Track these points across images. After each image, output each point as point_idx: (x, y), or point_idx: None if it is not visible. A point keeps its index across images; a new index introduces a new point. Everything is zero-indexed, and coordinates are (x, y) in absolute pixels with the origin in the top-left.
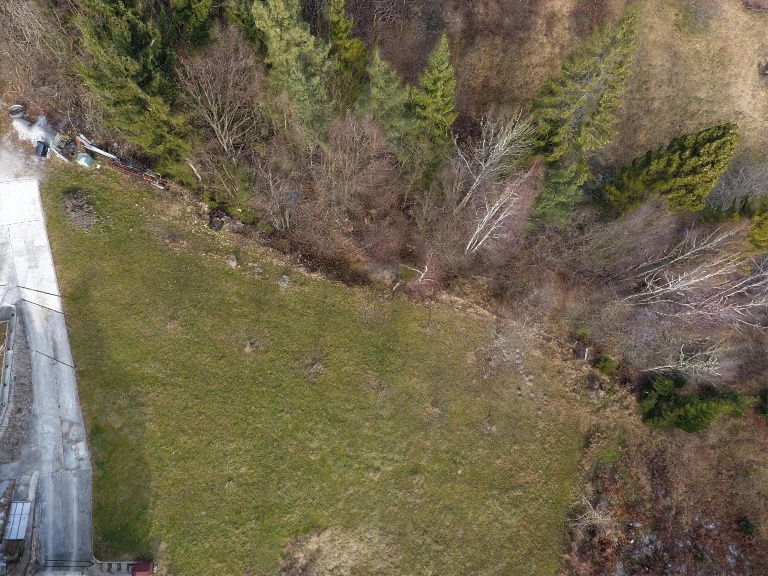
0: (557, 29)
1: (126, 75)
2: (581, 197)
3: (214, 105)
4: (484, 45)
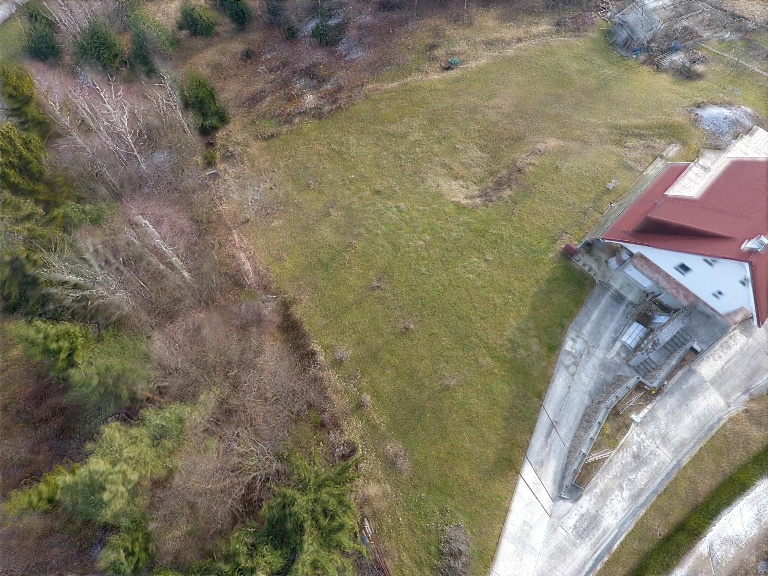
0: None
1: (310, 486)
2: None
3: None
4: None
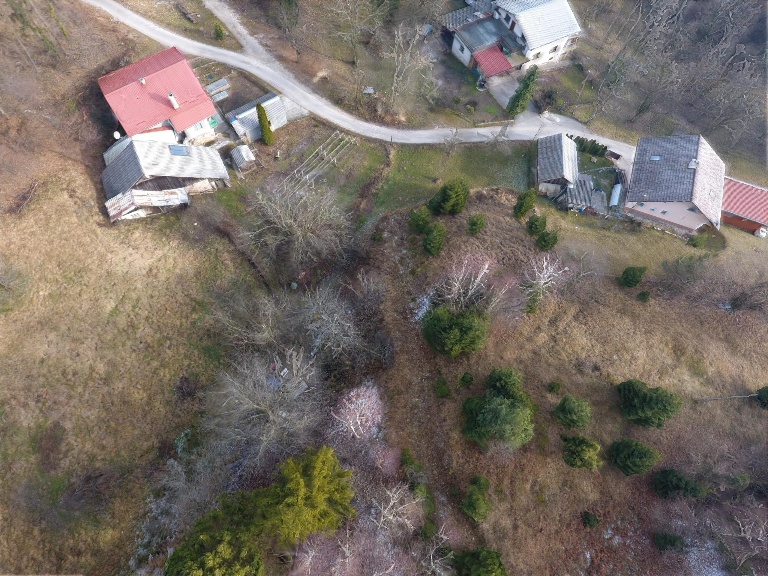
0: None
1: None
2: None
3: None
4: None
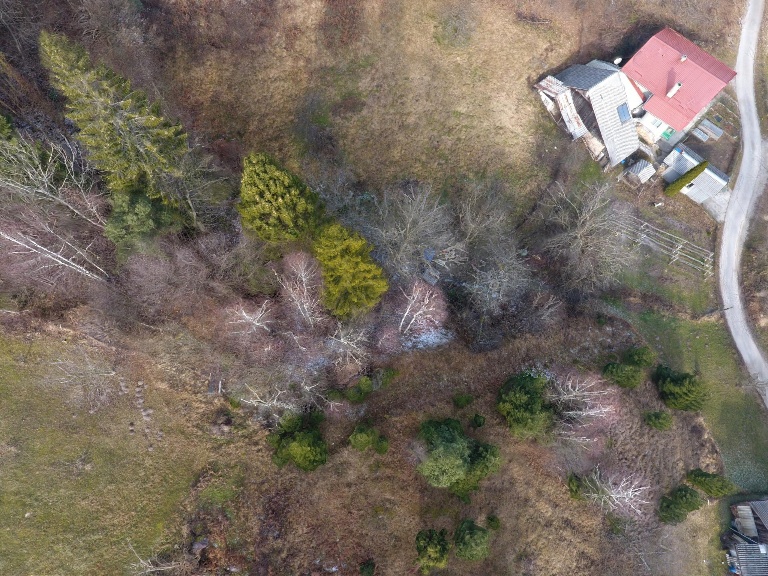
0: (301, 42)
1: None
2: (179, 225)
3: None
4: (209, 59)
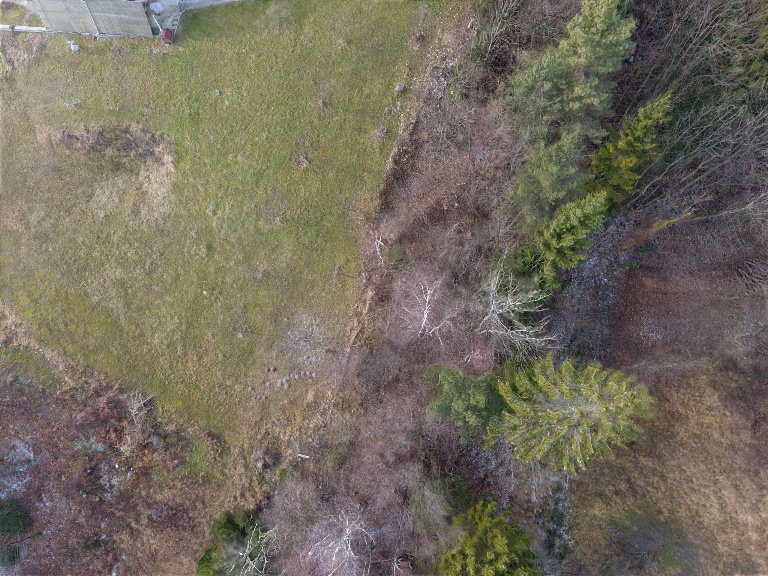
0: None
1: None
2: None
3: (514, 6)
4: (734, 414)
